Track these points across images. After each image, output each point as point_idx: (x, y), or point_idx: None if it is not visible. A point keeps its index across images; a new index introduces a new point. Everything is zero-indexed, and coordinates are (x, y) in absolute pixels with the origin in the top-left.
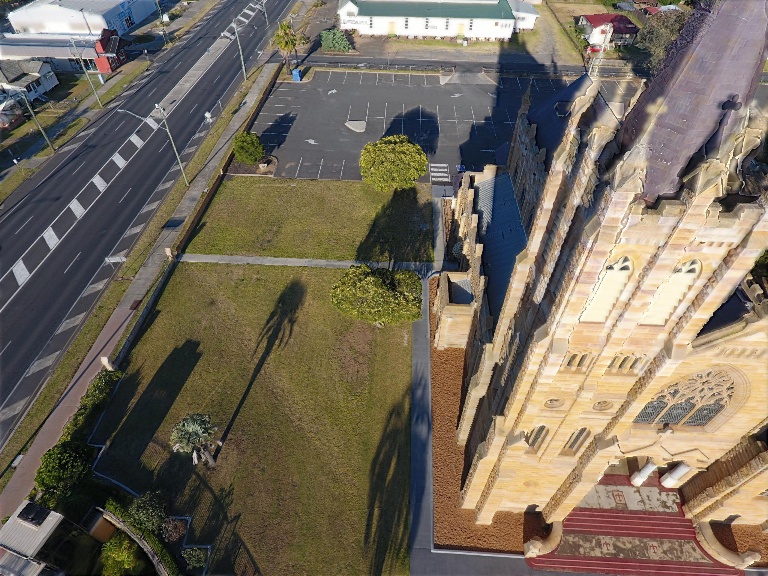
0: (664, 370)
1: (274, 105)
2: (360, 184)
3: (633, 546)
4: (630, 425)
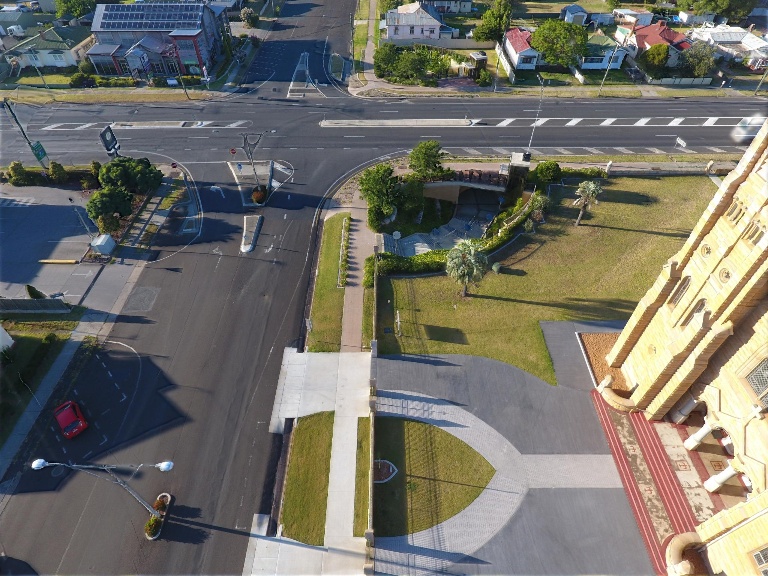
0: (763, 239)
1: None
2: None
3: (642, 472)
4: (729, 325)
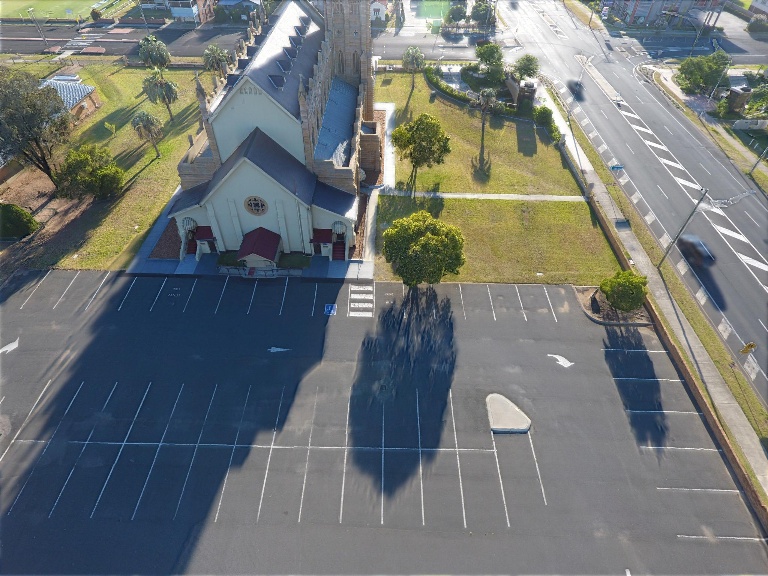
0: None
1: (716, 490)
2: (461, 277)
3: None
4: None
